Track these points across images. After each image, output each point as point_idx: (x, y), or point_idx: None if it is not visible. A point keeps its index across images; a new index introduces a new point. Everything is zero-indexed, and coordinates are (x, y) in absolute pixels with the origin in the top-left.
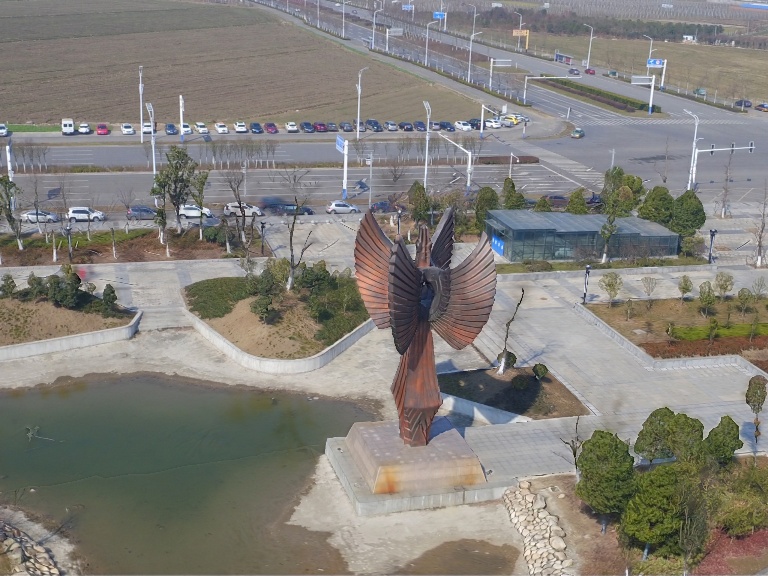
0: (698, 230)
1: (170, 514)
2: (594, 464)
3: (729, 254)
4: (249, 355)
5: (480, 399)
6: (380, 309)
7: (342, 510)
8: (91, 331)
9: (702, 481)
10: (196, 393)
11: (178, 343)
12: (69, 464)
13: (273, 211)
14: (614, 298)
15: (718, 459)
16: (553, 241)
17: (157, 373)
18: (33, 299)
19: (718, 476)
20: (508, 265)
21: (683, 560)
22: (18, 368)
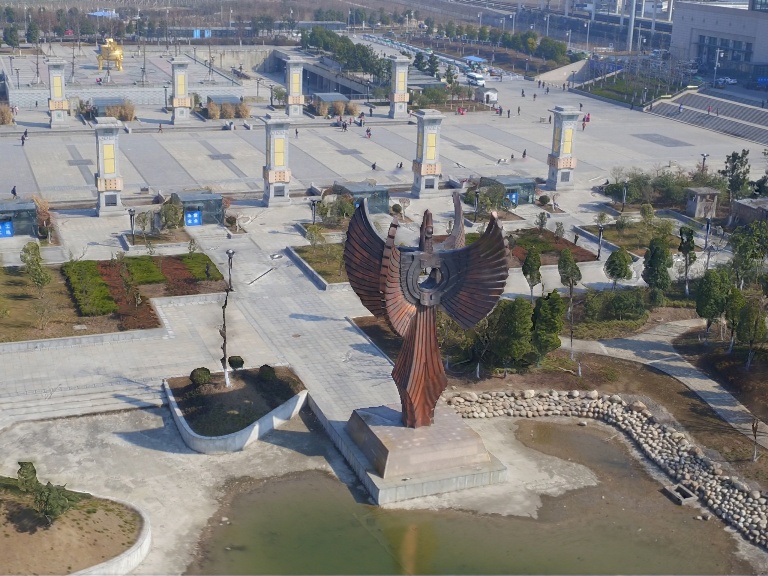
0: None
1: None
2: None
3: None
4: (126, 554)
5: (265, 409)
6: None
7: (500, 490)
8: None
9: None
10: None
11: None
12: None
13: None
14: None
15: None
16: None
17: None
18: None
19: None
20: None
21: None
22: None
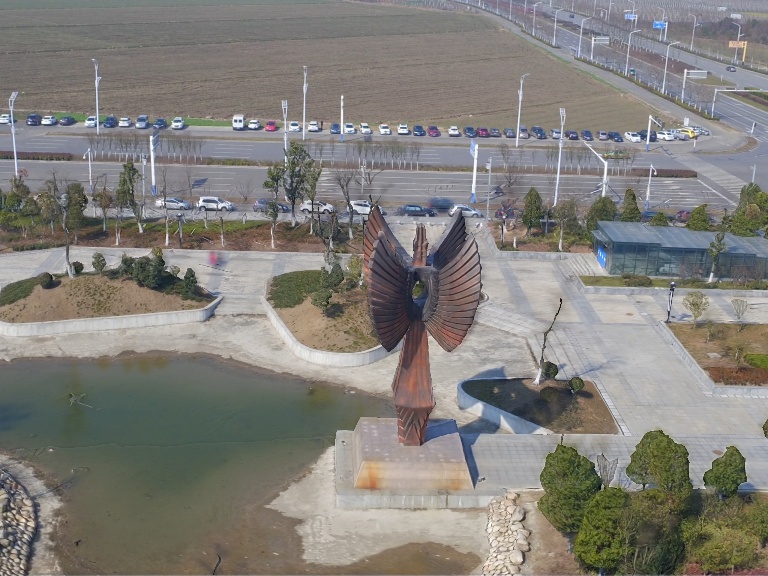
0: None
1: (163, 485)
2: (554, 479)
3: None
4: (302, 345)
5: (508, 407)
6: None
7: (324, 500)
8: (167, 311)
9: (698, 512)
10: (241, 377)
11: (246, 329)
12: (95, 430)
13: (395, 211)
14: (707, 319)
15: (720, 491)
16: (657, 256)
17: (214, 355)
18: (120, 277)
19: (715, 509)
20: (606, 278)
21: None
22: (91, 340)
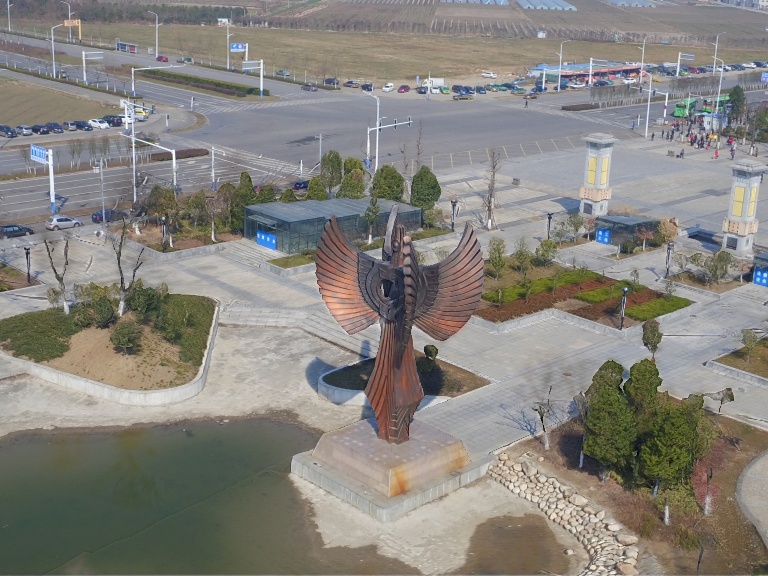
0: (436, 202)
1: (202, 570)
2: (605, 421)
3: (455, 221)
4: (129, 391)
5: None
6: (349, 315)
7: (363, 521)
8: None
9: None
10: (98, 442)
11: (26, 394)
12: (37, 548)
13: None
14: None
15: None
16: None
17: (34, 430)
18: None
19: None
20: (288, 258)
21: (683, 488)
22: None
